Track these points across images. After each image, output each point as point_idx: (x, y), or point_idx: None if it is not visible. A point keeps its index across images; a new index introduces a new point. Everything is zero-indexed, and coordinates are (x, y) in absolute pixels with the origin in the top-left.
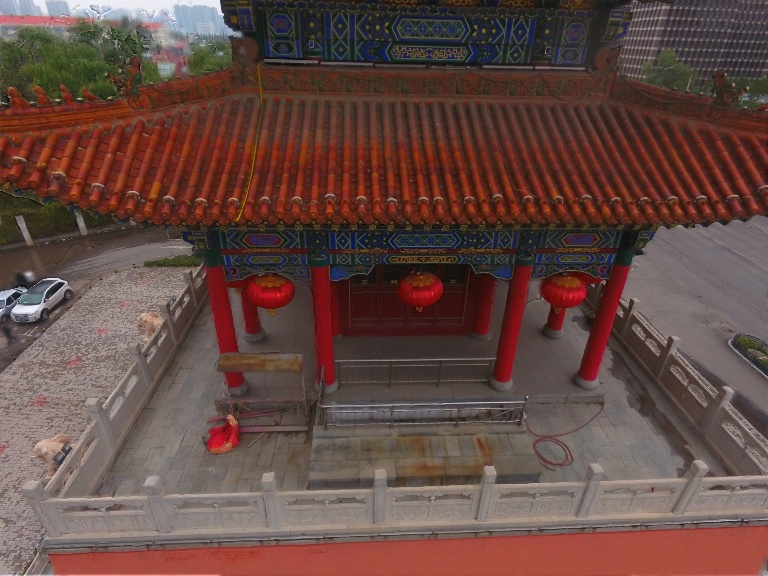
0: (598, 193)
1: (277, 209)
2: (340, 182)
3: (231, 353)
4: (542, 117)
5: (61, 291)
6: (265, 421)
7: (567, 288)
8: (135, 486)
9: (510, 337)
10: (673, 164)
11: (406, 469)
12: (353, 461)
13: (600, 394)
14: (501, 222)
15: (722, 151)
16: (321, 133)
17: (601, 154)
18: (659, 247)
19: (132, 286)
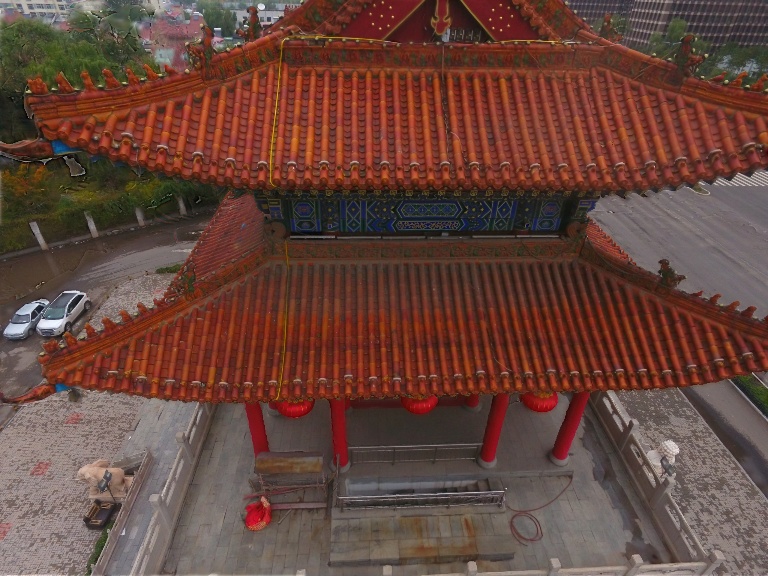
0: (561, 365)
1: (308, 391)
2: (355, 355)
3: (264, 455)
4: (522, 276)
5: (81, 303)
6: (291, 497)
7: (542, 399)
8: (191, 563)
9: (494, 431)
10: (625, 331)
11: (407, 550)
12: (365, 542)
13: (570, 470)
14: (483, 393)
15: (664, 325)
16: (339, 301)
17: (567, 319)
18: (652, 248)
19: (147, 295)
